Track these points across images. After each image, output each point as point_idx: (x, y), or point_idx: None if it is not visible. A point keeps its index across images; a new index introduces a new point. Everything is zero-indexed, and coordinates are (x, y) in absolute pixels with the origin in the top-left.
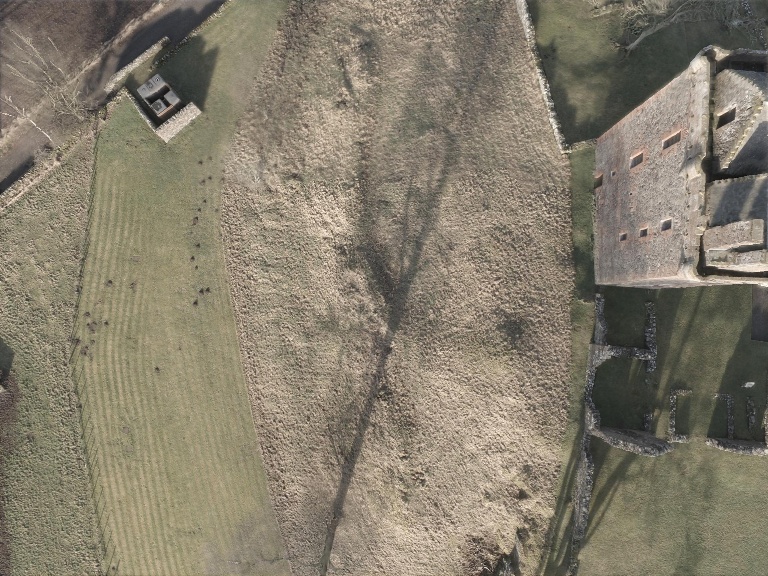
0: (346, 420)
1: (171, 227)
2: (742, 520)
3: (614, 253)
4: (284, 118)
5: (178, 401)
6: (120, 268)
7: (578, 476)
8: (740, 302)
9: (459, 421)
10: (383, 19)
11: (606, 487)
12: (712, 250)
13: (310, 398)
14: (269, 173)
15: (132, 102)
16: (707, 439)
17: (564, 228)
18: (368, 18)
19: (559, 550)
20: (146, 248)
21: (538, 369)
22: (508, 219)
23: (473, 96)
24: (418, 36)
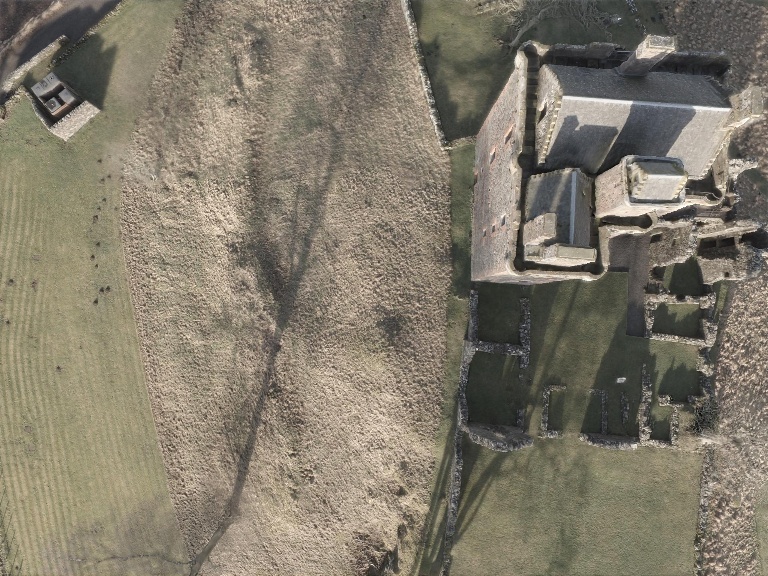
0: (240, 418)
1: (71, 226)
2: (617, 515)
3: (480, 249)
4: (180, 116)
5: (79, 400)
6: (21, 267)
7: (451, 472)
8: (616, 298)
9: (344, 418)
10: (275, 17)
11: (479, 483)
12: (528, 245)
13: (207, 396)
14: (166, 171)
15: (31, 101)
16: (580, 434)
17: (443, 225)
18: (261, 16)
19: (433, 546)
20: (47, 247)
21: (414, 365)
22: (389, 216)
23: (358, 93)
24: (308, 34)
